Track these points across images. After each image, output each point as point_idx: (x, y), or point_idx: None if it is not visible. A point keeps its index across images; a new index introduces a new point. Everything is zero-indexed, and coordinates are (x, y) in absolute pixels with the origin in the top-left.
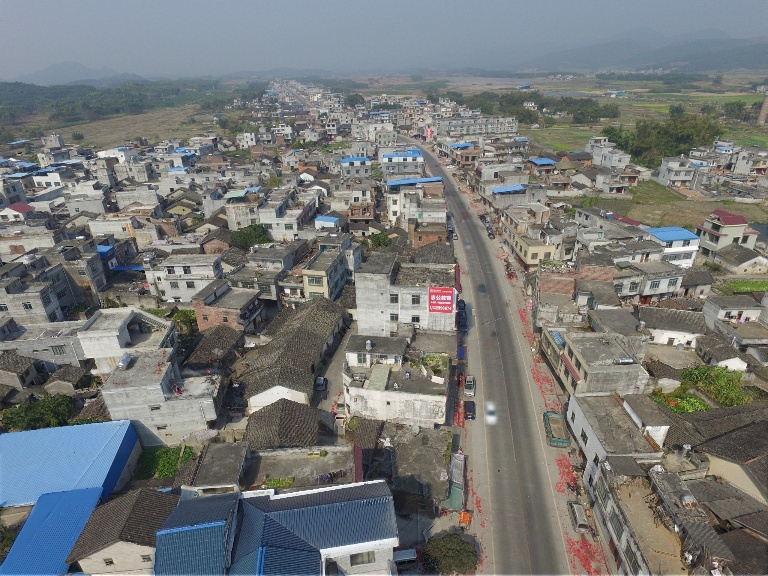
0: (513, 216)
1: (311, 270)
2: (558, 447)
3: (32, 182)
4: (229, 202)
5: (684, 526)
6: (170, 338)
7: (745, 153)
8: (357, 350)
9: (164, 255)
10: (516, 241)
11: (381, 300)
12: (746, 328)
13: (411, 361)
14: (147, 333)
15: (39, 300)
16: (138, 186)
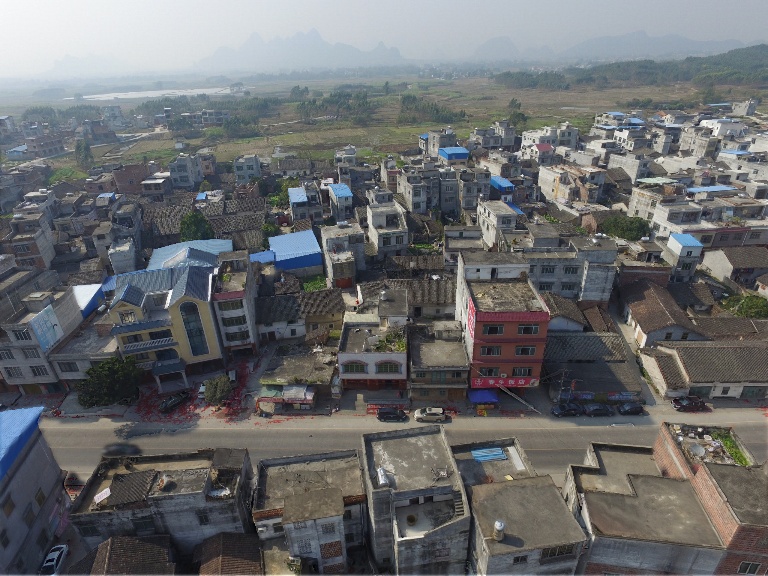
0: None
1: None
2: None
3: (613, 135)
4: (648, 187)
5: None
6: (398, 237)
7: None
8: None
9: (552, 211)
10: None
11: None
12: None
13: None
14: (397, 228)
15: (412, 191)
16: (630, 153)
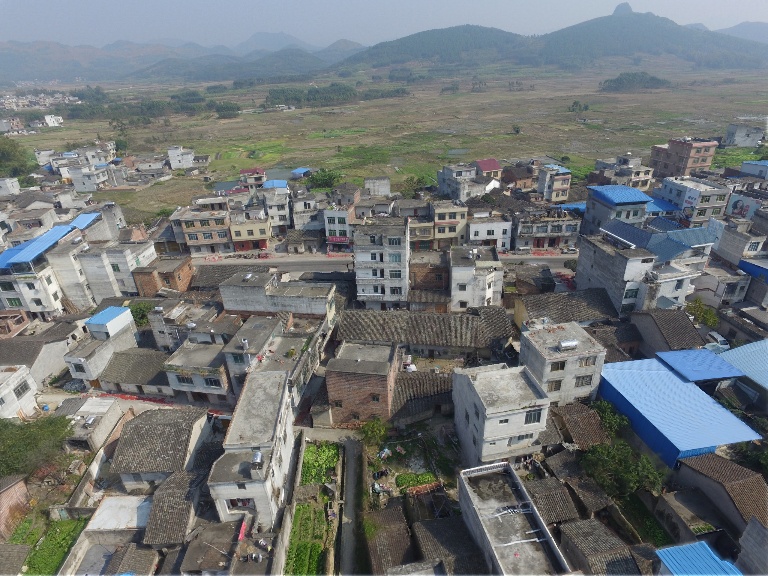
0: (205, 217)
1: (331, 291)
2: None
3: None
4: None
5: None
6: None
7: (92, 152)
8: (473, 262)
9: None
10: (236, 231)
11: None
12: None
13: None
14: None
15: None
16: None
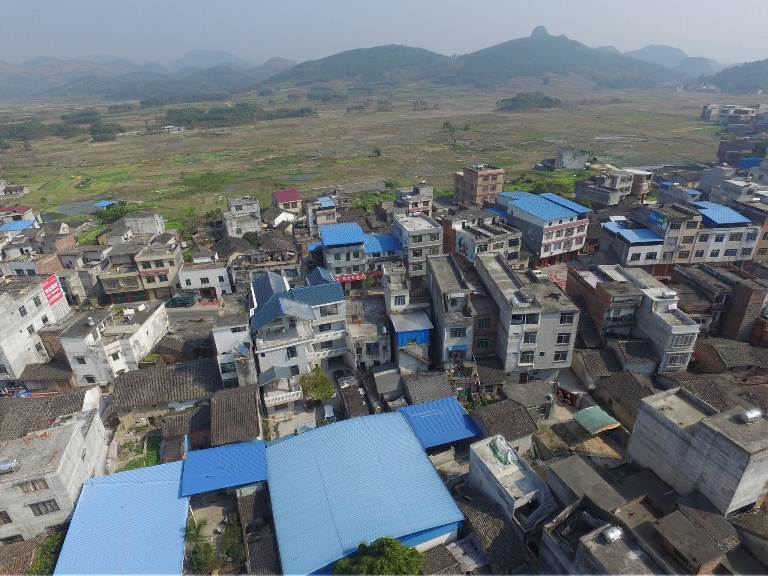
0: None
1: None
2: (194, 304)
3: None
4: None
5: (272, 251)
6: None
7: None
8: (89, 330)
9: None
10: None
11: (14, 320)
12: (136, 240)
13: (110, 319)
14: None
15: None
16: None
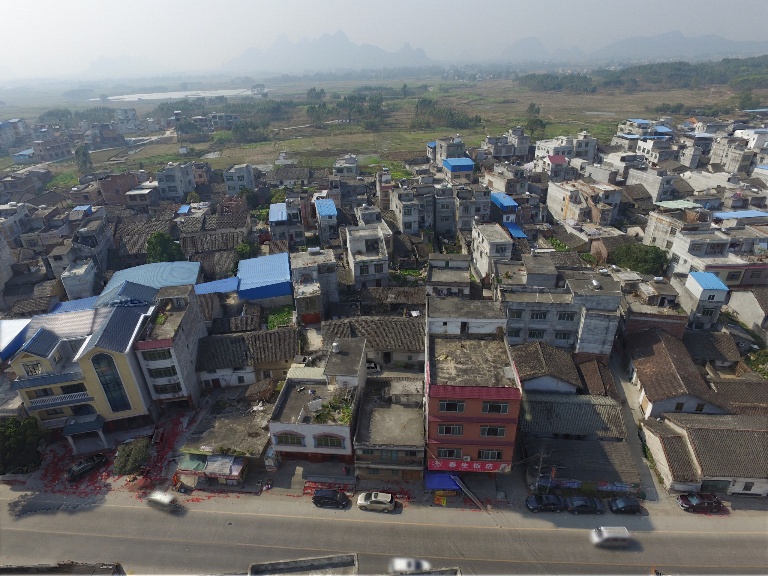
0: None
1: (499, 292)
2: None
3: (637, 145)
4: (668, 212)
5: None
6: (377, 266)
7: None
8: None
9: (559, 233)
10: None
11: None
12: None
13: None
14: (377, 254)
15: (402, 210)
16: (651, 168)
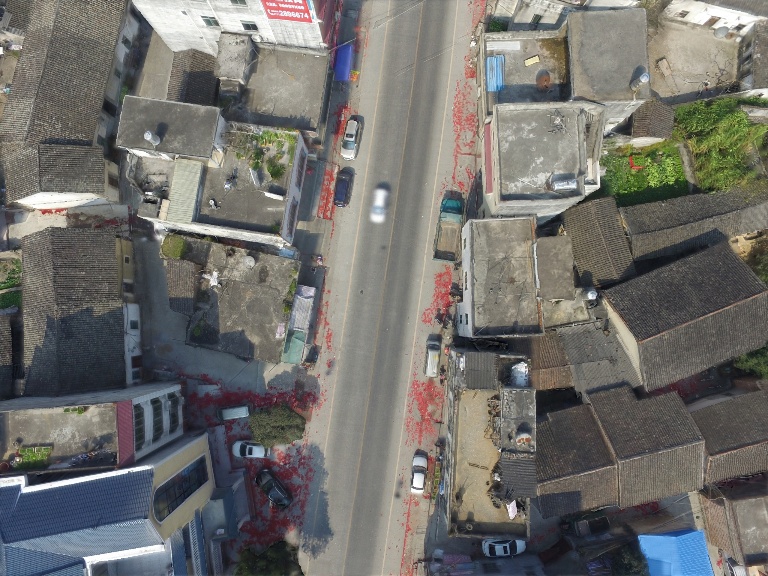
0: None
1: None
2: None
3: None
4: None
5: None
6: None
7: None
8: (137, 143)
9: None
10: None
11: None
12: None
13: None
14: None
15: None
16: None
